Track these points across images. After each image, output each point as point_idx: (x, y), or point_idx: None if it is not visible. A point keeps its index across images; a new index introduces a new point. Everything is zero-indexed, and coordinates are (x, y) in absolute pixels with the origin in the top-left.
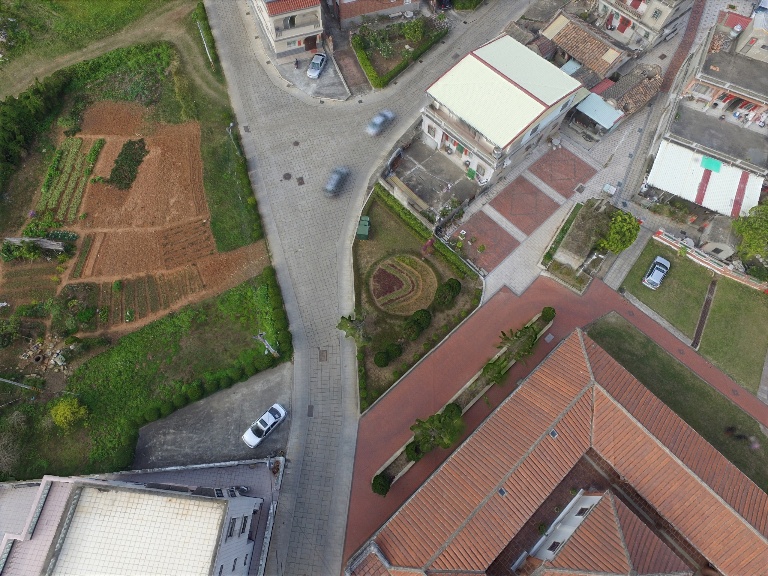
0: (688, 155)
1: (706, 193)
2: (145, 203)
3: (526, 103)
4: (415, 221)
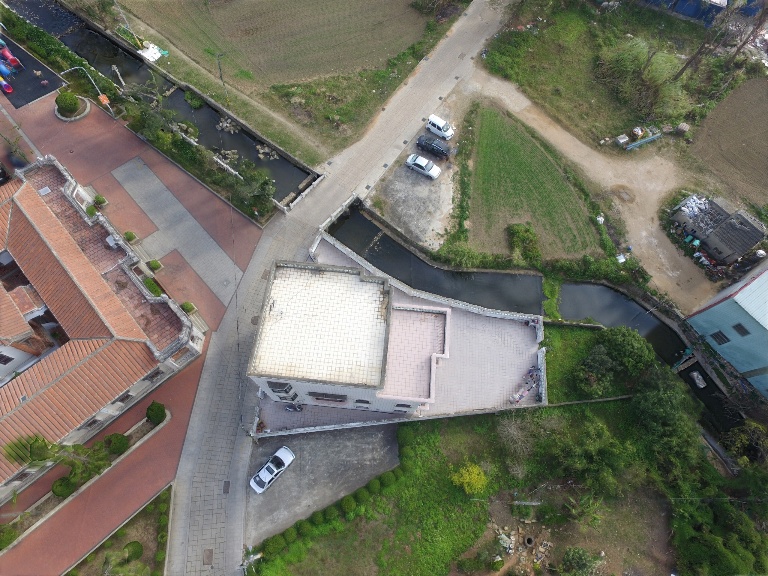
0: None
1: None
2: None
3: None
4: None
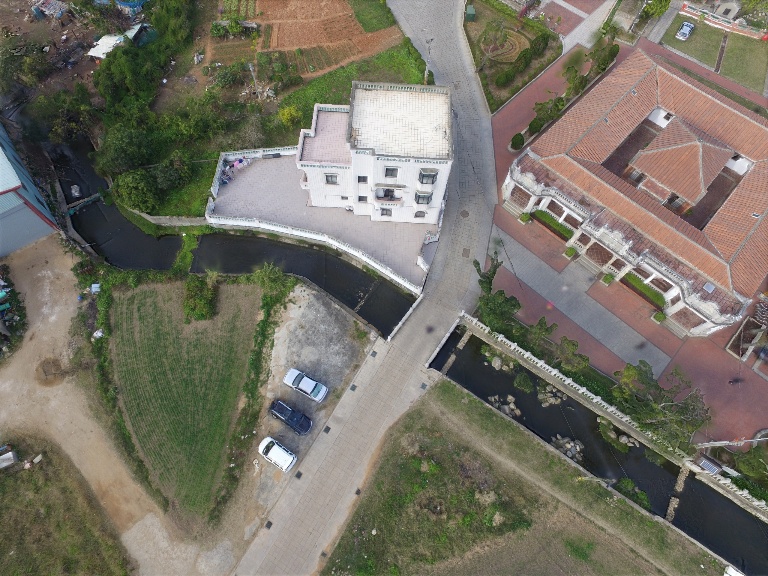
0: None
1: None
2: (303, 5)
3: None
4: (507, 7)
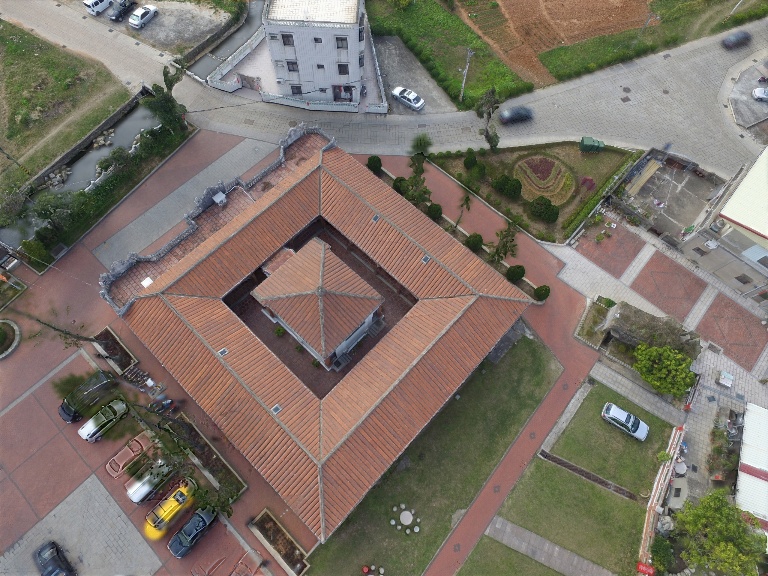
0: None
1: (762, 480)
2: (567, 6)
3: None
4: None
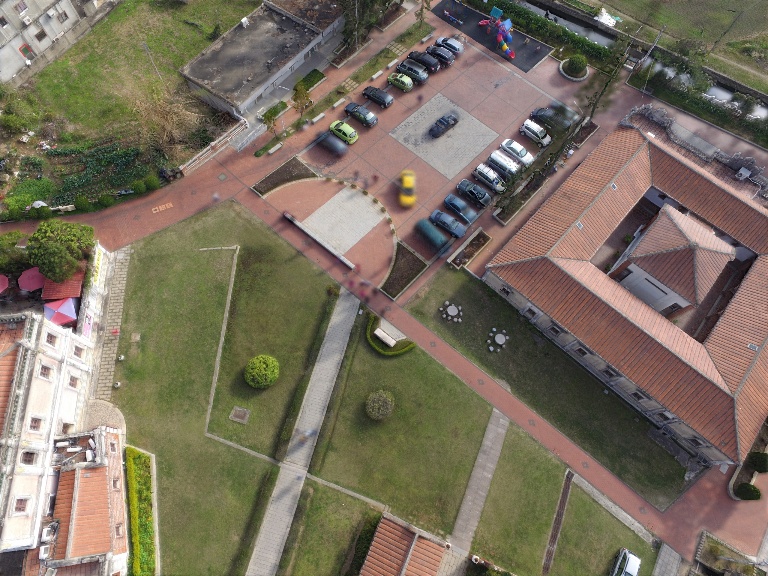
0: None
1: None
2: None
3: None
4: None
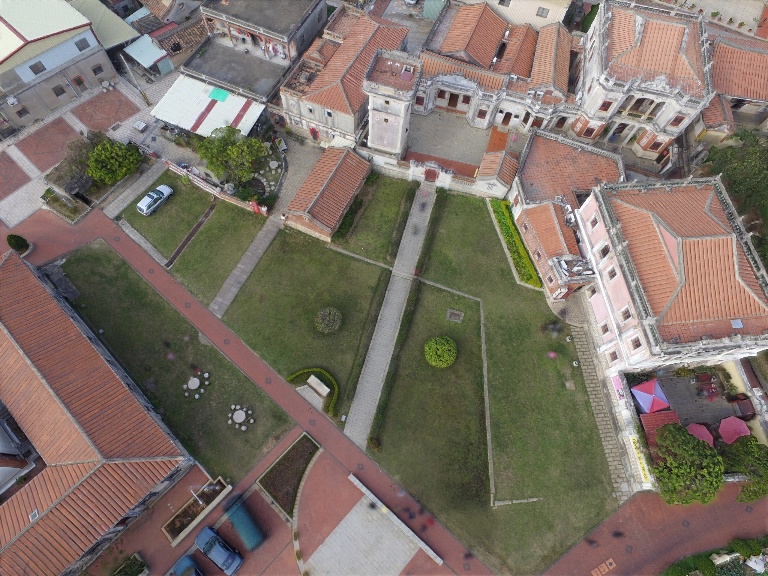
0: (200, 87)
1: (204, 121)
2: None
3: (7, 39)
4: None
